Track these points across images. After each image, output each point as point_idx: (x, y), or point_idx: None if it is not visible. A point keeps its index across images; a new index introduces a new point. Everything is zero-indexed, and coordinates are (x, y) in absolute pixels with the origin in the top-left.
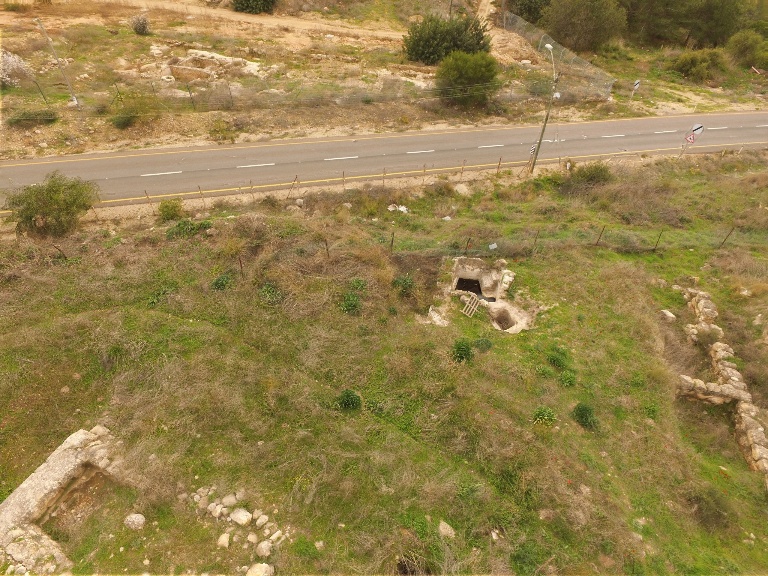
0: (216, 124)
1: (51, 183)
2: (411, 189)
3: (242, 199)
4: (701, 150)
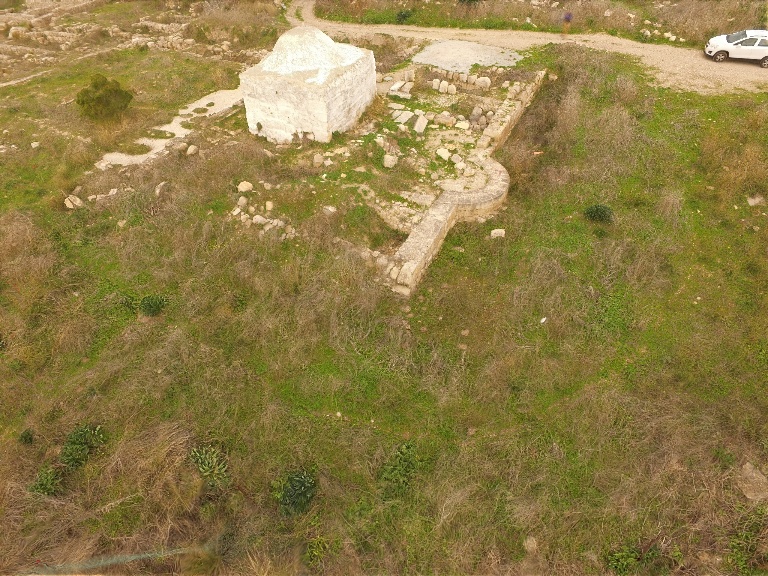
0: None
1: None
2: None
3: None
4: None
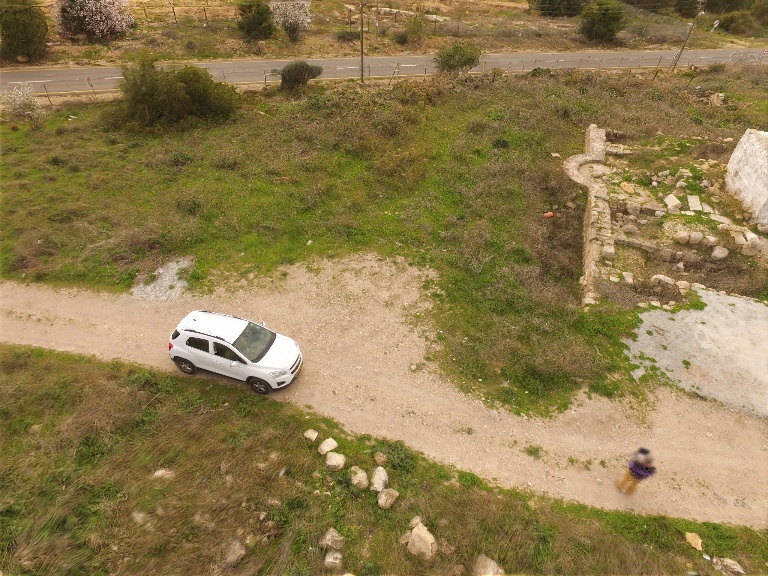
0: None
1: (460, 47)
2: (611, 75)
3: None
4: None
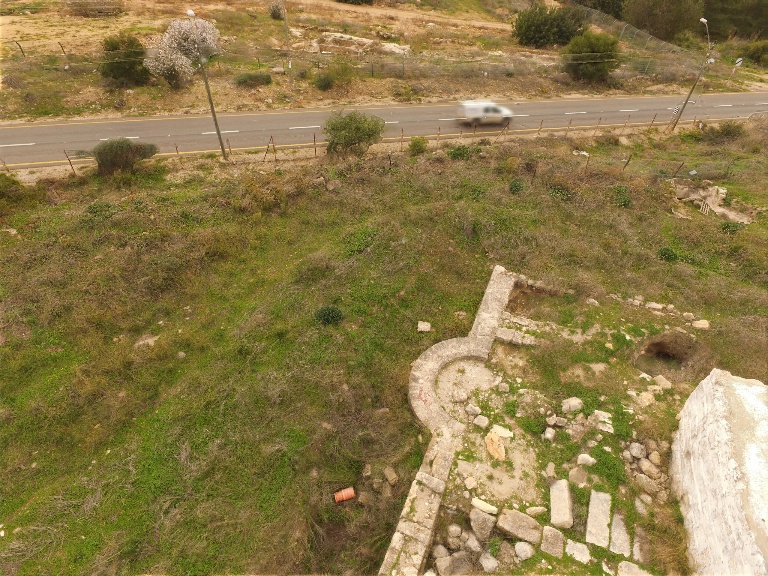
0: (396, 89)
1: (355, 115)
2: (585, 139)
3: (461, 142)
4: None
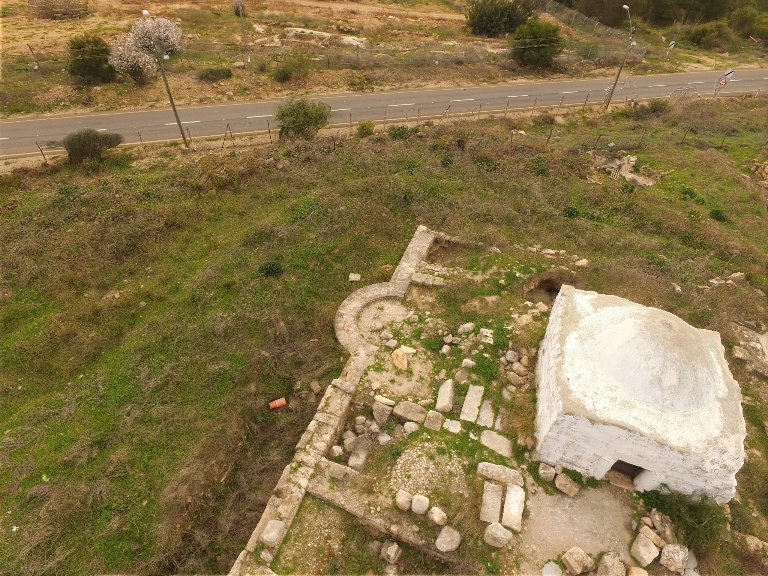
0: (351, 79)
1: (303, 102)
2: (524, 119)
3: (407, 125)
4: (727, 95)
